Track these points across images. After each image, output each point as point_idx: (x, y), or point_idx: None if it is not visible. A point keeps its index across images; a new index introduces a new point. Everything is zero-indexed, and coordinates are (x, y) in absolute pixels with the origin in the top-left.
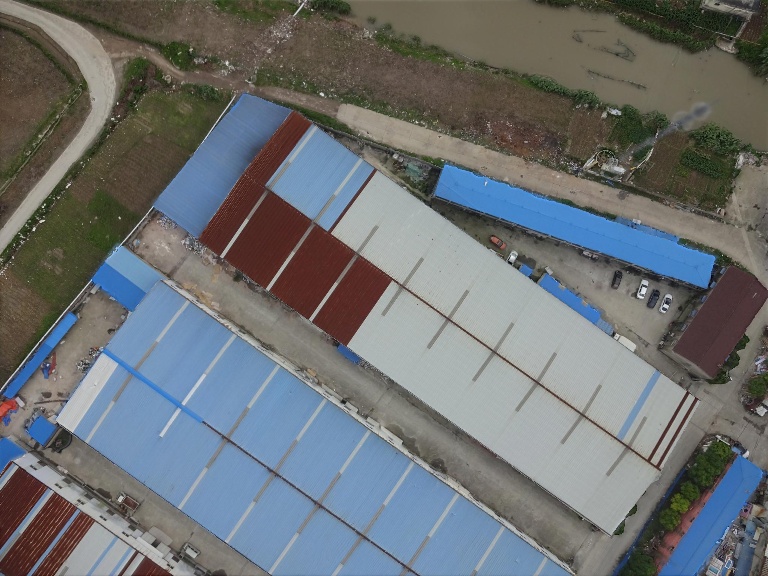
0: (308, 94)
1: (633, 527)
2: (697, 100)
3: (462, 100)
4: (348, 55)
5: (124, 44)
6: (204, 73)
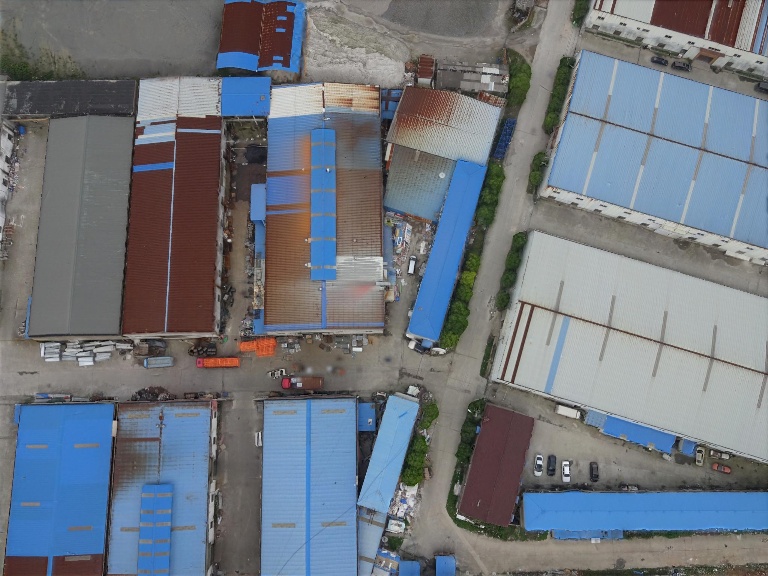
0: None
1: (492, 246)
2: None
3: None
4: None
5: None
6: None
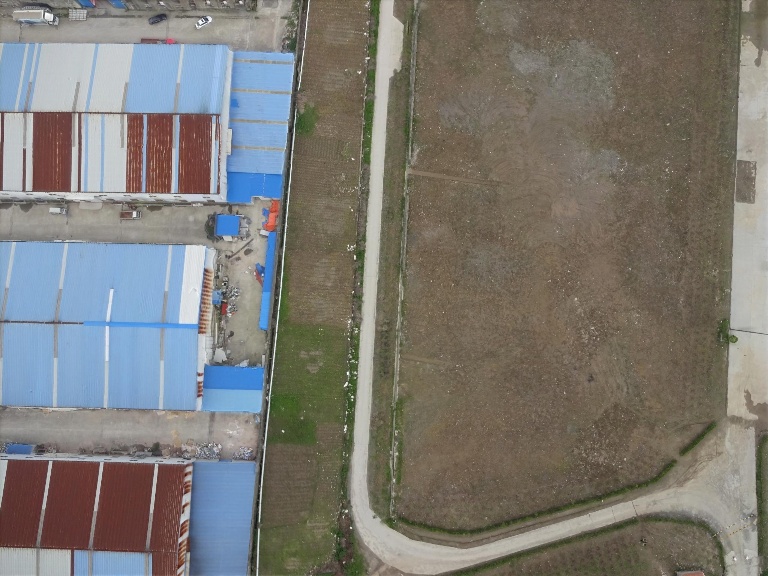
0: None
1: None
2: None
3: None
4: None
5: None
6: None
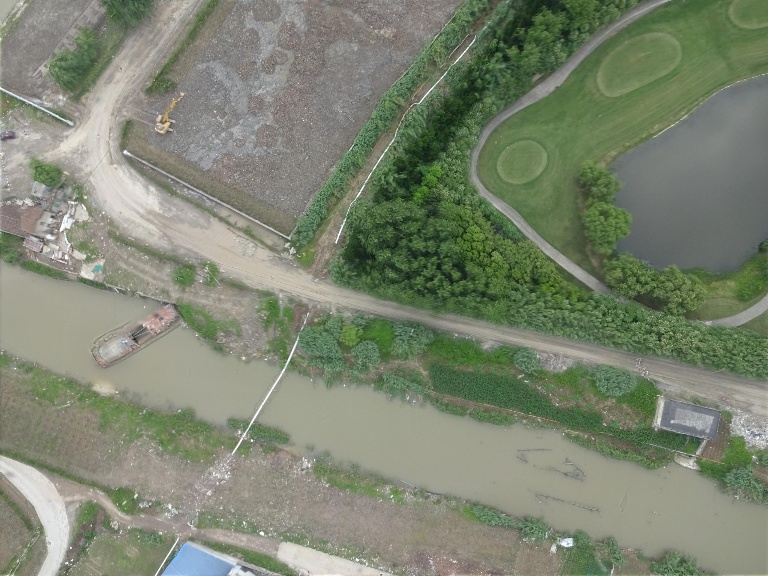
0: (248, 534)
1: None
2: (657, 524)
3: (402, 537)
4: (286, 493)
5: (76, 487)
6: (149, 517)
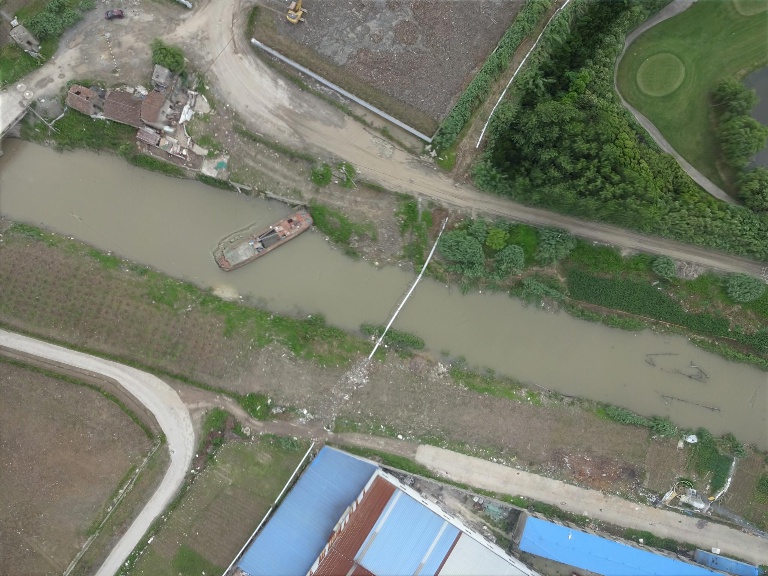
0: (386, 437)
1: None
2: None
3: (540, 437)
4: (425, 397)
5: (201, 394)
6: (282, 422)
